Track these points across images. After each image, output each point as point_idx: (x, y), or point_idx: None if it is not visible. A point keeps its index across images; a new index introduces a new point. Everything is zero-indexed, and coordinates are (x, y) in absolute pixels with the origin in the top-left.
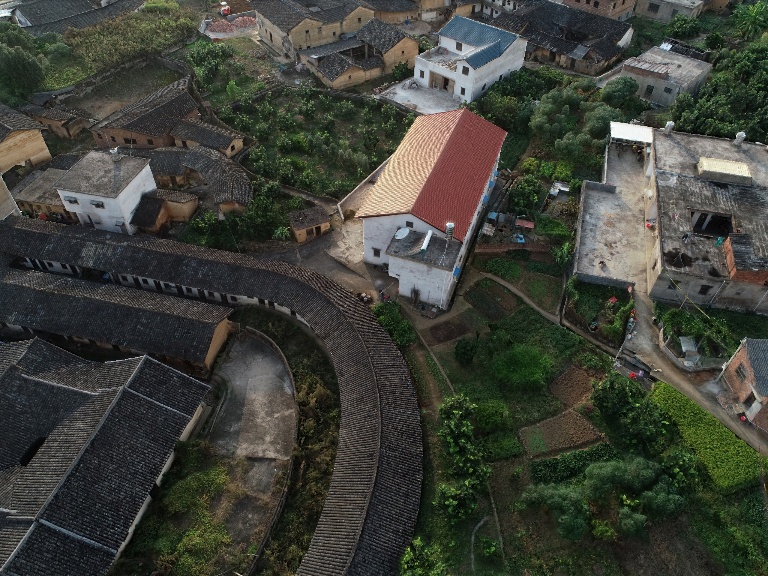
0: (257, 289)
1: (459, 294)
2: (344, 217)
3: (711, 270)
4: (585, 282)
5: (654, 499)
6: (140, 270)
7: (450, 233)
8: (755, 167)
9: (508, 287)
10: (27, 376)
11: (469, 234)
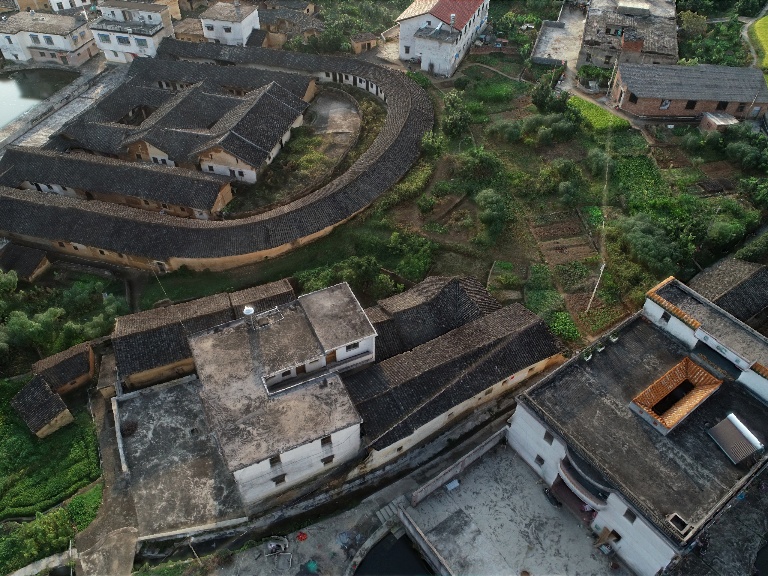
0: (333, 67)
1: (458, 71)
2: (385, 41)
3: (611, 47)
4: (537, 63)
5: (557, 125)
6: (259, 60)
7: (453, 21)
8: (655, 8)
9: (489, 68)
10: (205, 93)
11: (466, 41)
